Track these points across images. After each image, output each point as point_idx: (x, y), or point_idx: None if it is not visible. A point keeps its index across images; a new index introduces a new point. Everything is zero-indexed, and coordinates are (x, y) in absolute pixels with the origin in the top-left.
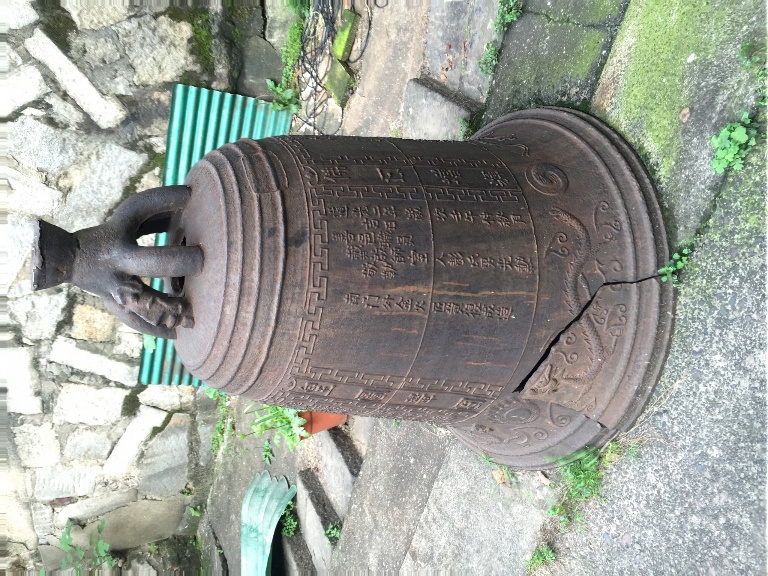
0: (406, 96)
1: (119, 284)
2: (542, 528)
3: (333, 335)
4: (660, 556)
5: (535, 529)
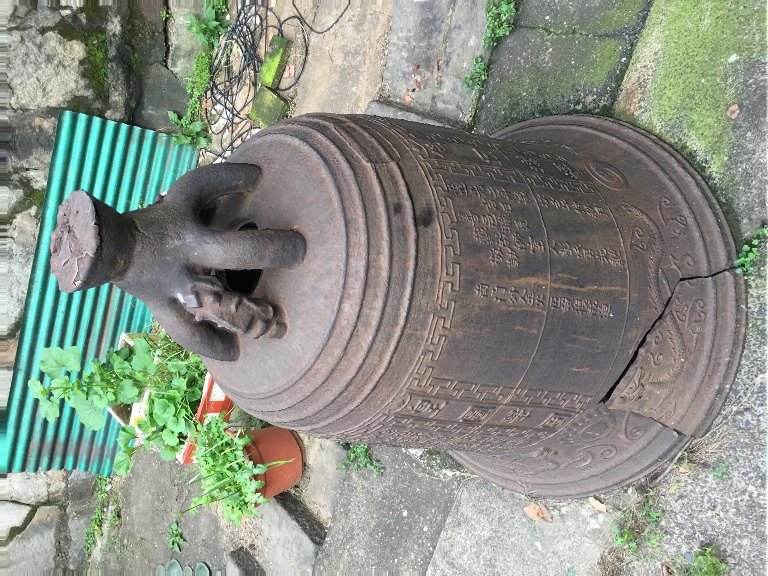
0: None
1: (193, 279)
2: (601, 561)
3: (462, 335)
4: (762, 566)
5: (591, 564)
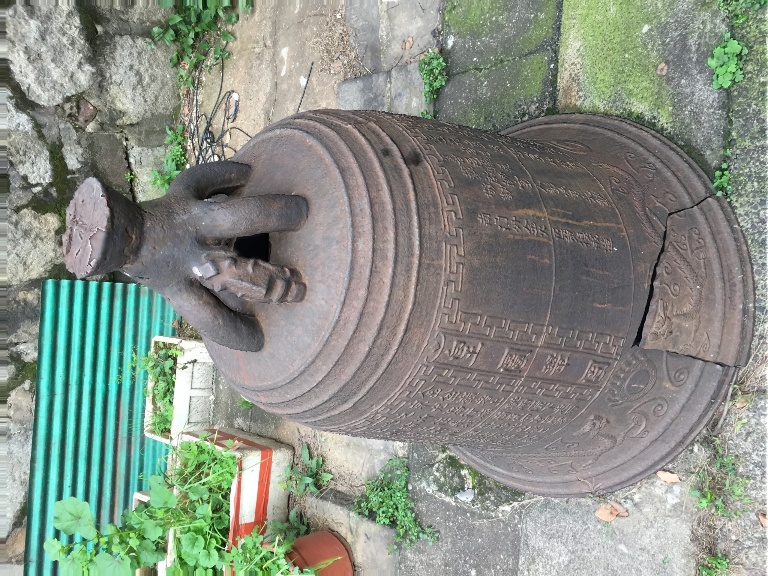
0: None
1: (205, 249)
2: (693, 537)
3: (478, 263)
4: None
5: (684, 544)
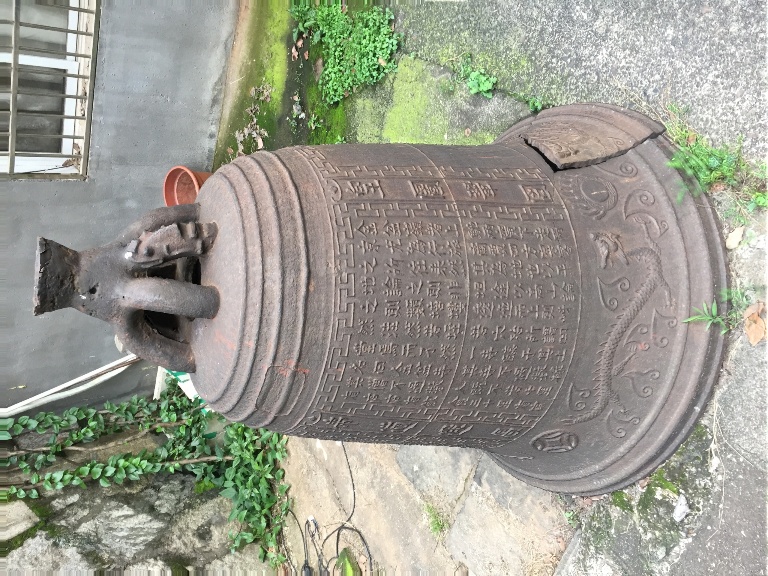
0: (404, 470)
1: None
2: None
3: None
4: None
5: None
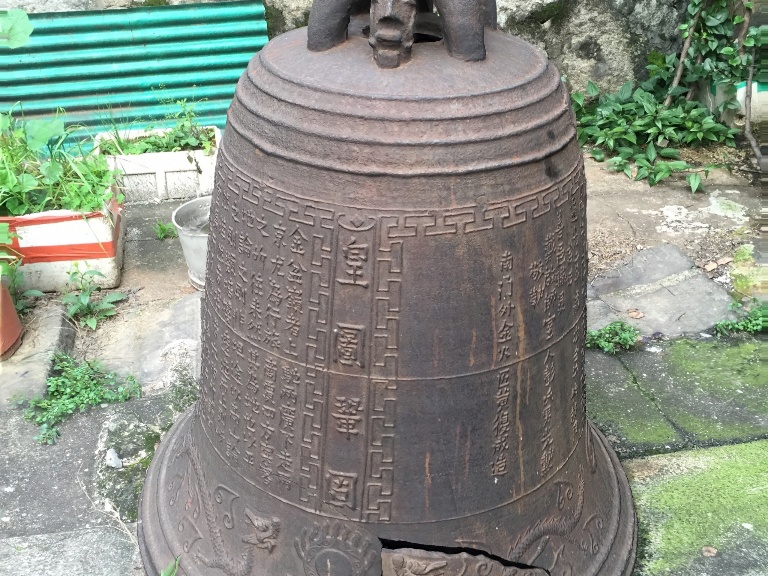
0: None
1: None
2: None
3: (459, 255)
4: None
5: None
